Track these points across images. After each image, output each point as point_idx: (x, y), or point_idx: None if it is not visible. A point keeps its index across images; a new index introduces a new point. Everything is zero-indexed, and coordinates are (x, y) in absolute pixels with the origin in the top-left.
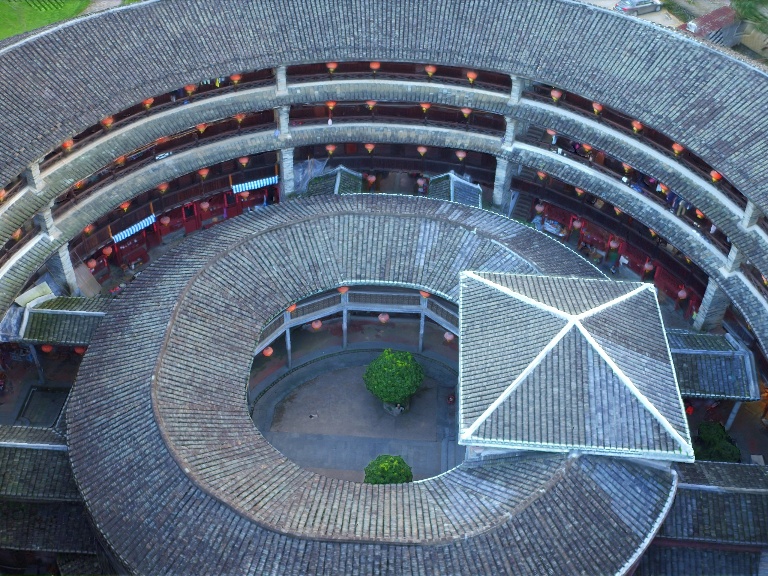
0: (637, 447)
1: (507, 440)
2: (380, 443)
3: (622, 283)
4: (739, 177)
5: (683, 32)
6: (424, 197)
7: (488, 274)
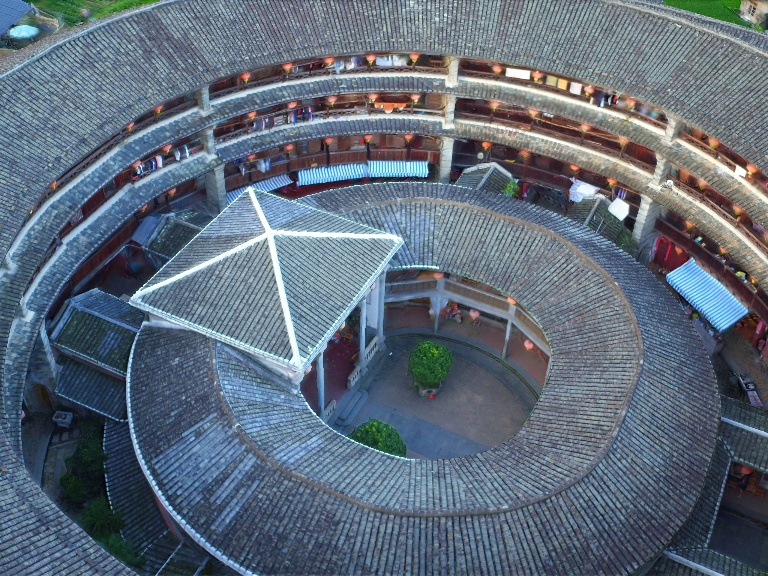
0: (283, 199)
1: (371, 228)
2: (407, 442)
3: (160, 305)
4: (3, 238)
5: None
6: (234, 562)
7: (277, 354)
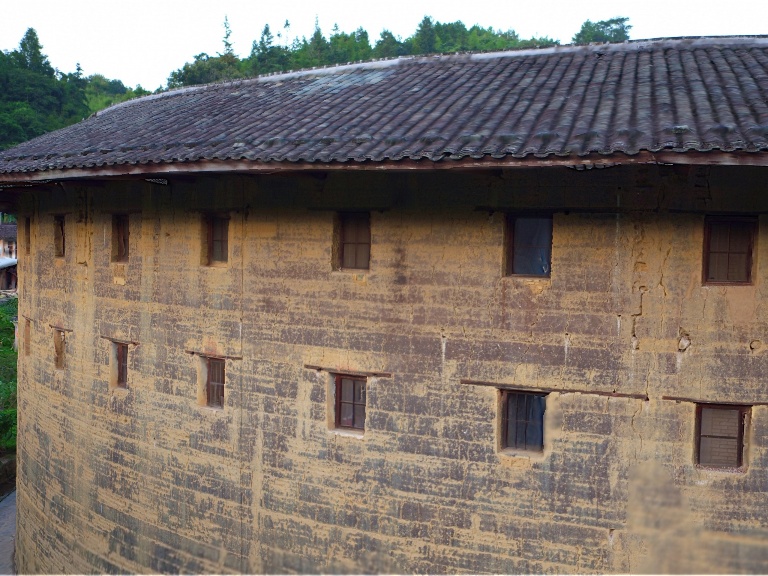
0: None
1: None
2: None
3: None
4: None
5: (204, 147)
6: None
7: None
